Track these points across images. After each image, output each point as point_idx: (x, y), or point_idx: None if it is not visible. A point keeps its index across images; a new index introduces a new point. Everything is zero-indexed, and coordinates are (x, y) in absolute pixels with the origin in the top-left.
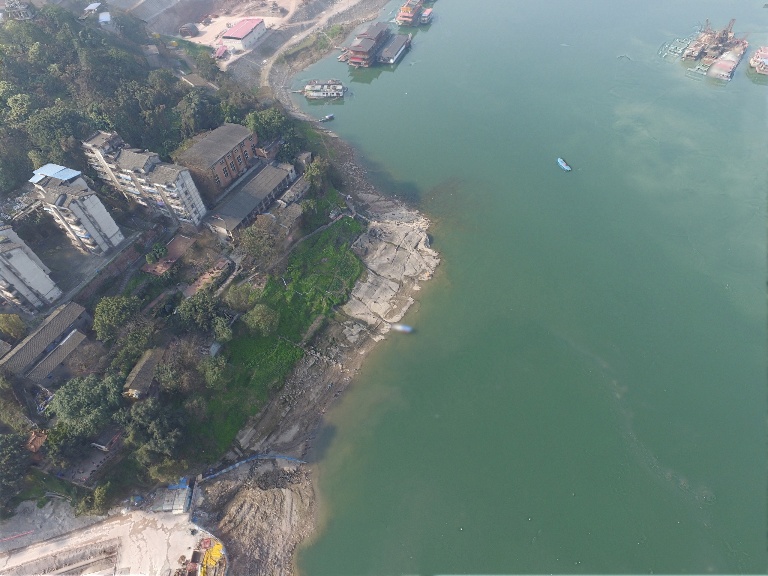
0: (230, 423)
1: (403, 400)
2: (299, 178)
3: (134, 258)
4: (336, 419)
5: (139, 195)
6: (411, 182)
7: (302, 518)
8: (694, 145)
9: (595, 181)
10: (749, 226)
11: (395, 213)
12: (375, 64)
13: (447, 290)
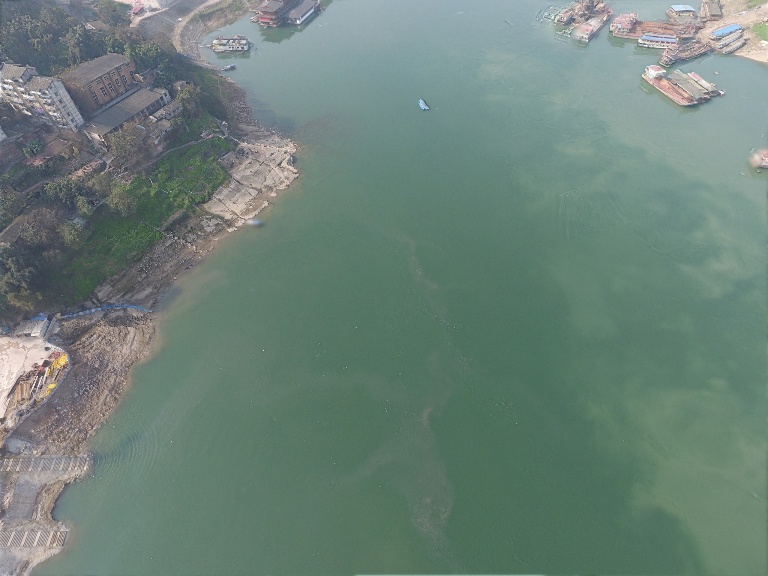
0: (89, 279)
1: (242, 271)
2: (172, 101)
3: (16, 154)
4: (184, 284)
5: (23, 105)
6: (290, 118)
7: (141, 346)
8: (538, 91)
9: (447, 118)
10: (558, 149)
11: (268, 140)
12: (284, 25)
13: (299, 196)
